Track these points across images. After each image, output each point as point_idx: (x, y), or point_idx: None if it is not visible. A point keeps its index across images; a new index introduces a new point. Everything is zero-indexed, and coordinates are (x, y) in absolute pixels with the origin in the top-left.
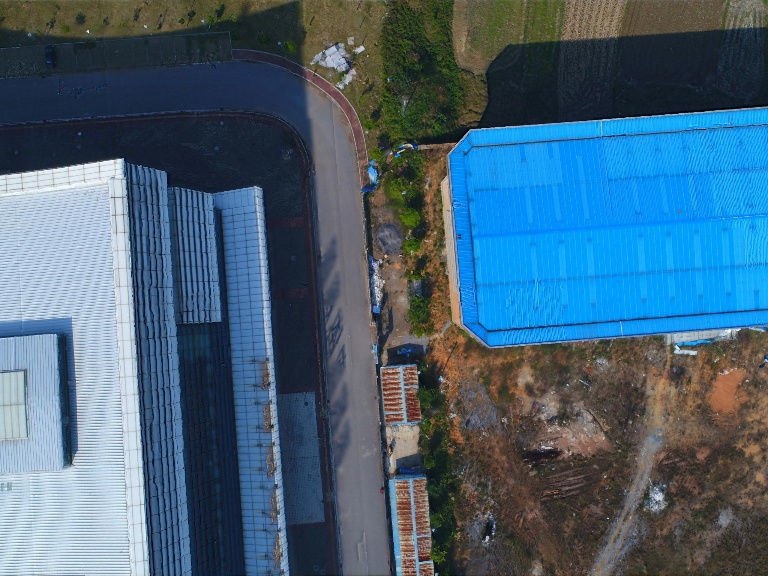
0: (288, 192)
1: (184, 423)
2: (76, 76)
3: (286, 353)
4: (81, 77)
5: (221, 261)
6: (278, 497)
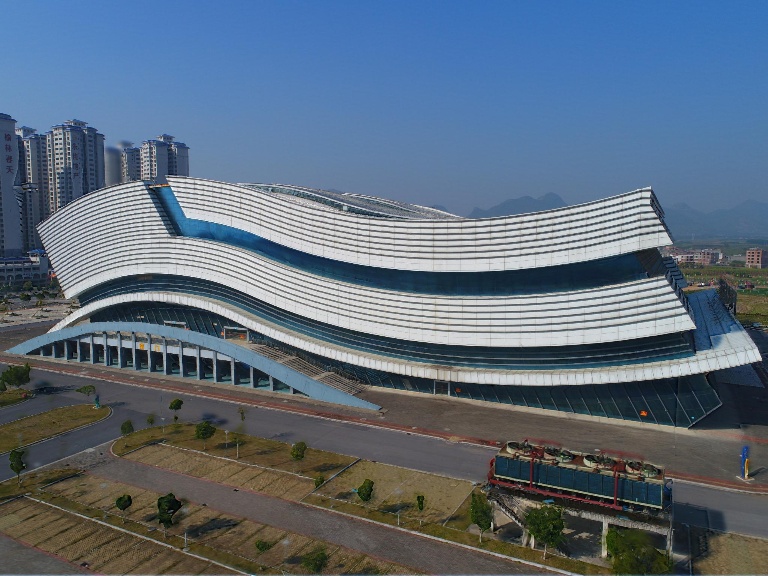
0: None
1: None
2: None
3: None
4: None
5: None
6: None
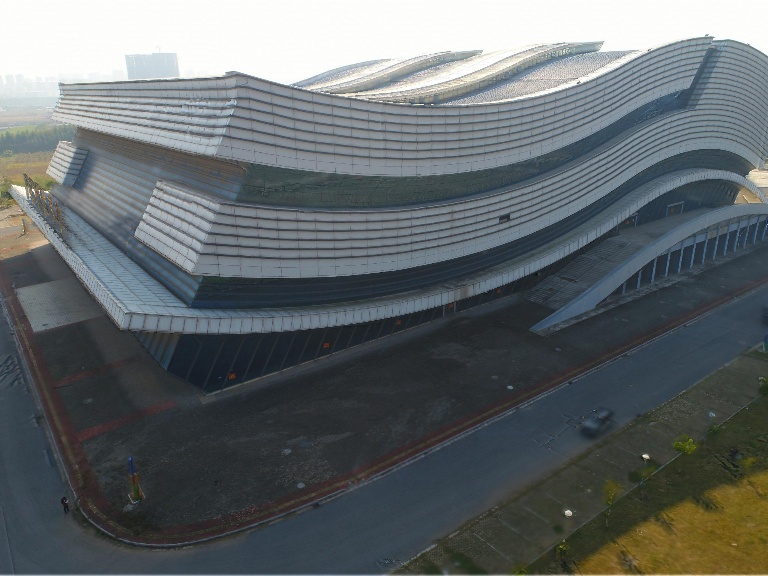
0: (118, 455)
1: (138, 179)
2: (601, 436)
3: (81, 341)
4: (593, 438)
5: (167, 283)
6: (42, 219)
